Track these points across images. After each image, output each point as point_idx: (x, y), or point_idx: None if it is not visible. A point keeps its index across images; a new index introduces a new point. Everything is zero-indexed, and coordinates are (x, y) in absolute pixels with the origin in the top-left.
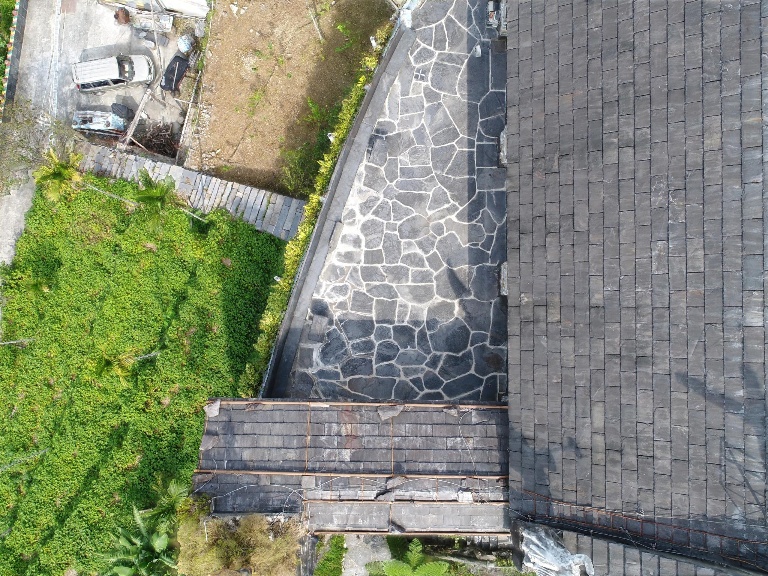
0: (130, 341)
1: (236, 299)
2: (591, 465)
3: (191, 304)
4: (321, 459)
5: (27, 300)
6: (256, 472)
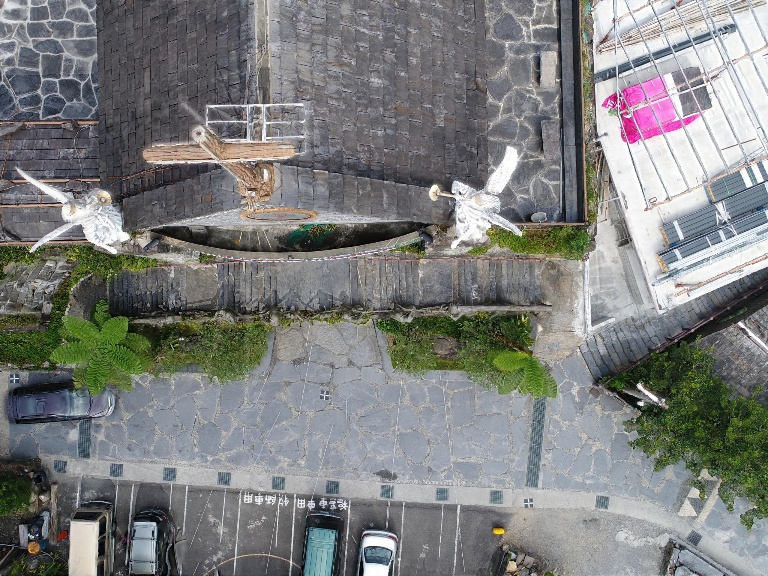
0: None
1: None
2: (144, 131)
3: None
4: None
5: None
6: None
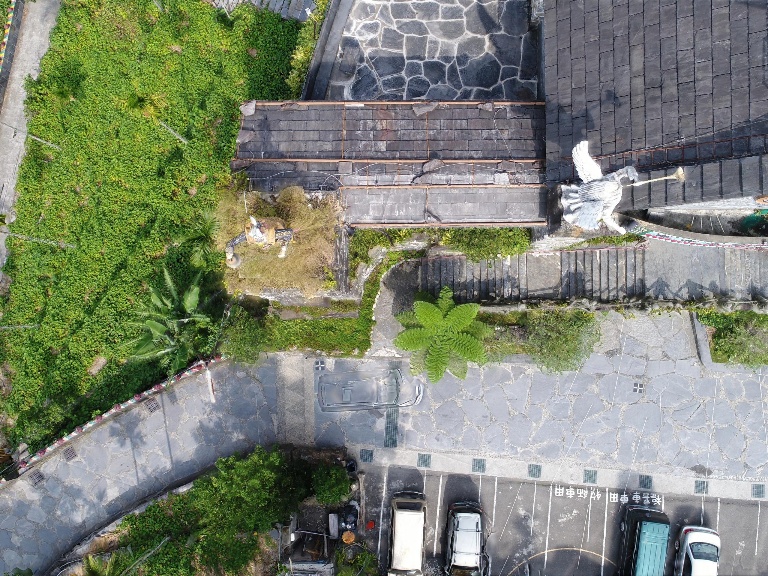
0: (156, 140)
1: (262, 88)
2: (630, 110)
3: (217, 93)
4: (357, 149)
5: (52, 115)
6: (293, 159)
